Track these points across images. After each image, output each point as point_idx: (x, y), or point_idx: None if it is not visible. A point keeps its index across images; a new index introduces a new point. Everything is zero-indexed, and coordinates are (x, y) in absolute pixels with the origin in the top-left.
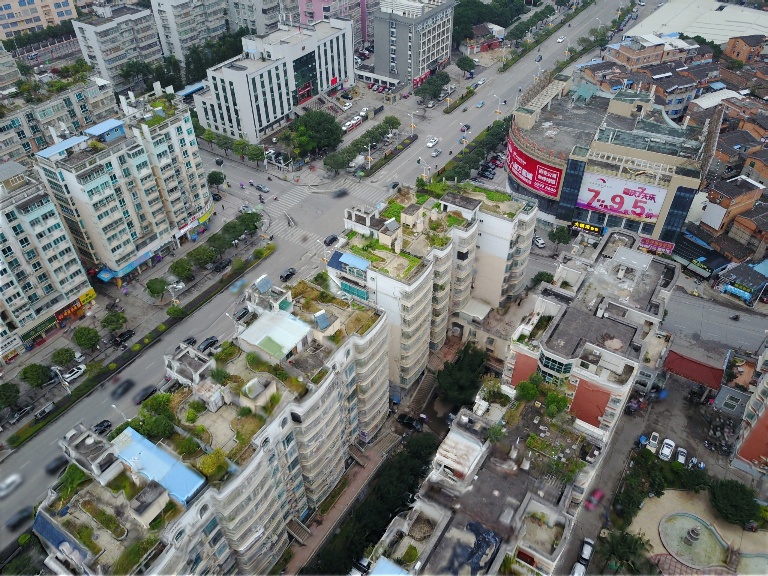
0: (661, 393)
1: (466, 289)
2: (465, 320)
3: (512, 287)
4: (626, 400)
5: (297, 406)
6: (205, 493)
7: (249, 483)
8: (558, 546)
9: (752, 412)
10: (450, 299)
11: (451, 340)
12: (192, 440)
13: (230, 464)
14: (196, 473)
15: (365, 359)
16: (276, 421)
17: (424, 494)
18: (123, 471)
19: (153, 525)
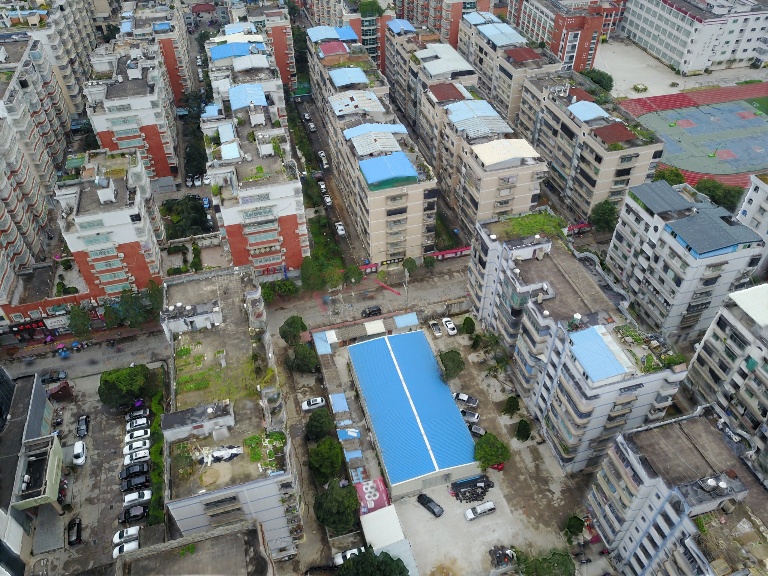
0: (199, 27)
1: (92, 4)
2: (100, 22)
3: (112, 4)
4: (186, 26)
5: (60, 1)
6: (50, 15)
7: (62, 19)
8: (173, 2)
9: (226, 2)
10: (88, 6)
11: (100, 38)
12: (31, 8)
13: (52, 10)
14: (42, 11)
15: (71, 2)
16: (56, 5)
17: (124, 2)
18: (12, 23)
19: (40, 23)
